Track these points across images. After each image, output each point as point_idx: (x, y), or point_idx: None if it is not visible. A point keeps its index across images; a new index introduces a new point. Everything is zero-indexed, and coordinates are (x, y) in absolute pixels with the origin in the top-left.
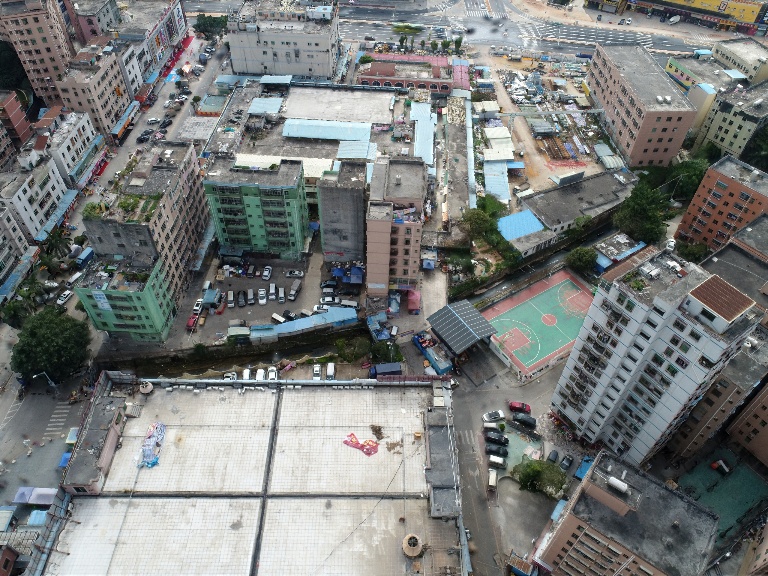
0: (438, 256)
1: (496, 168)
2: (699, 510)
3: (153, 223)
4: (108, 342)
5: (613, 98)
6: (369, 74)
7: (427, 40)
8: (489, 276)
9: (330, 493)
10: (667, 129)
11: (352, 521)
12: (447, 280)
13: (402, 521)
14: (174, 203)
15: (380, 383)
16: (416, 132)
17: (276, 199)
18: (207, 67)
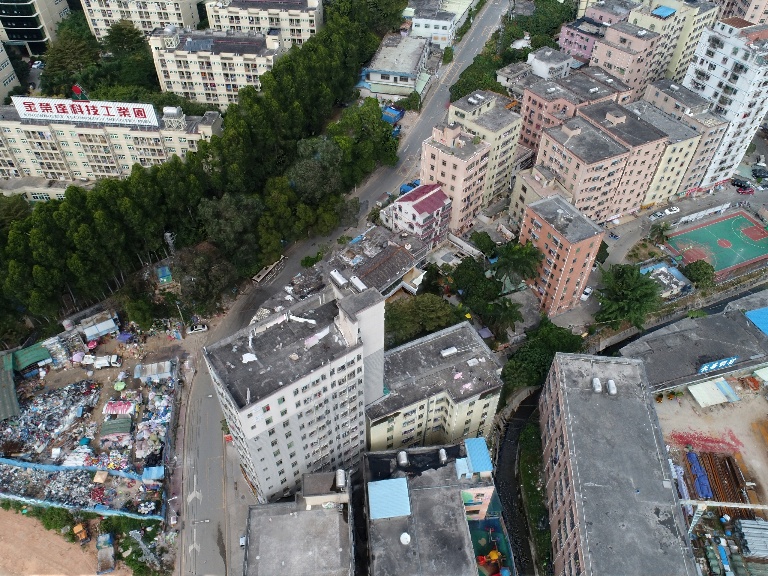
0: None
1: None
2: None
3: None
4: None
5: None
6: None
7: None
8: None
9: None
10: None
11: None
12: None
13: None
14: None
15: None
16: None
17: None
18: None
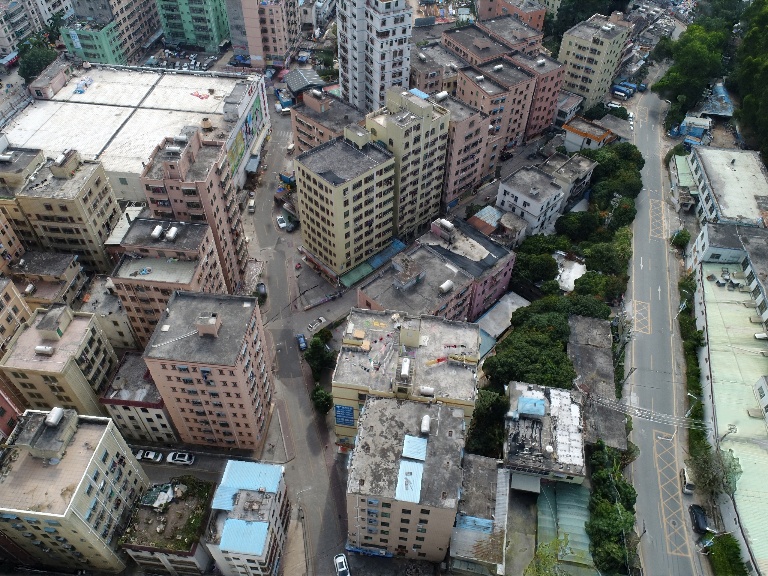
0: (311, 55)
1: None
2: (364, 115)
3: None
4: None
5: None
6: None
7: None
8: None
9: (173, 109)
10: None
11: (180, 118)
12: None
13: None
14: None
15: (222, 73)
16: None
17: None
18: None
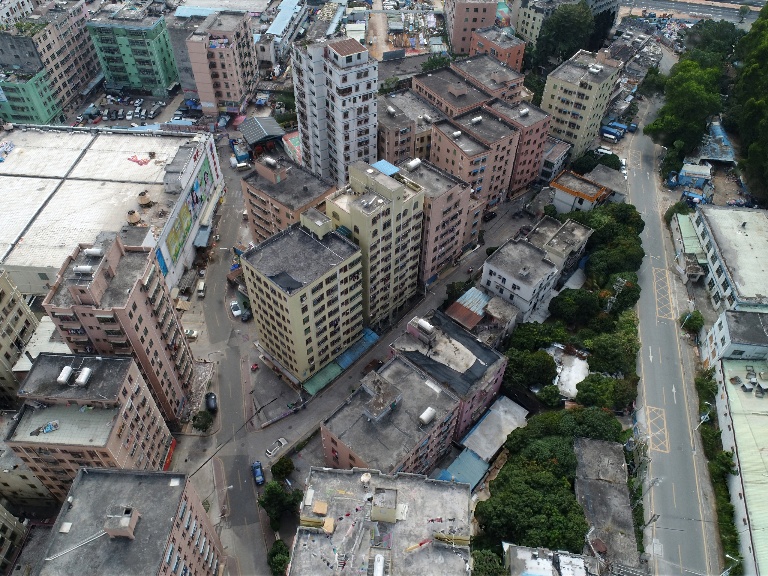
0: (269, 97)
1: None
2: (326, 184)
3: (37, 39)
4: None
5: (449, 1)
6: None
7: None
8: None
9: (107, 179)
10: (477, 19)
11: (115, 191)
12: None
13: (146, 192)
14: (61, 35)
15: (164, 132)
16: (277, 16)
17: (139, 39)
18: None
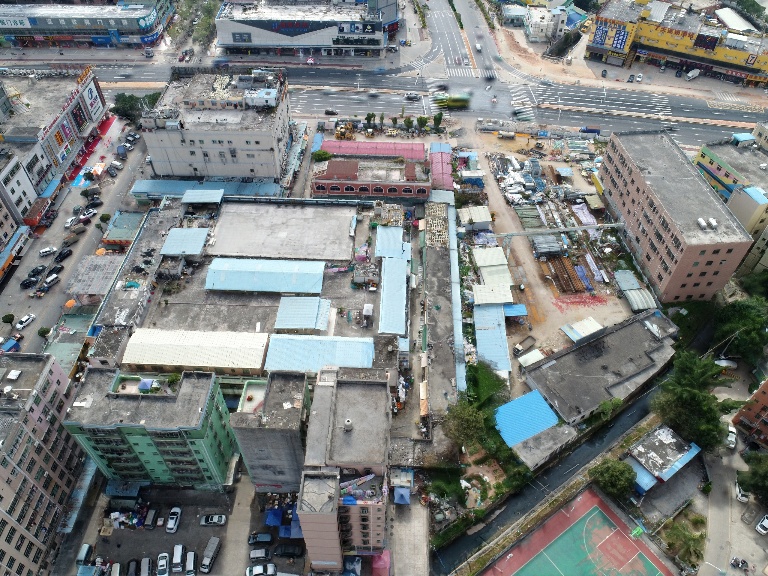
0: (415, 480)
1: (490, 316)
2: None
3: None
4: None
5: (636, 209)
6: (325, 178)
7: (400, 112)
8: (486, 507)
9: None
10: (713, 262)
11: None
12: (428, 523)
13: None
14: (14, 467)
15: None
16: (383, 278)
17: (173, 440)
18: (127, 162)
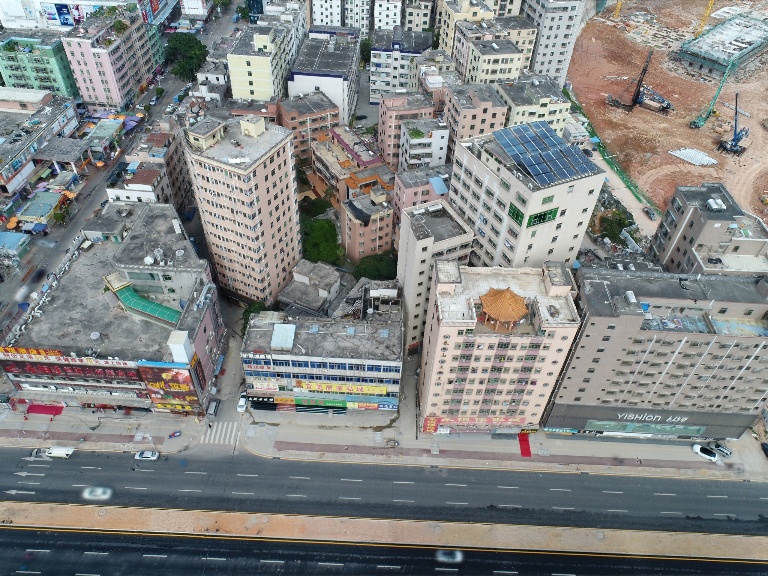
0: None
1: None
2: None
3: None
4: (164, 69)
5: None
6: None
7: None
8: None
9: None
10: None
11: None
12: None
13: None
14: None
15: None
16: None
17: None
18: None
